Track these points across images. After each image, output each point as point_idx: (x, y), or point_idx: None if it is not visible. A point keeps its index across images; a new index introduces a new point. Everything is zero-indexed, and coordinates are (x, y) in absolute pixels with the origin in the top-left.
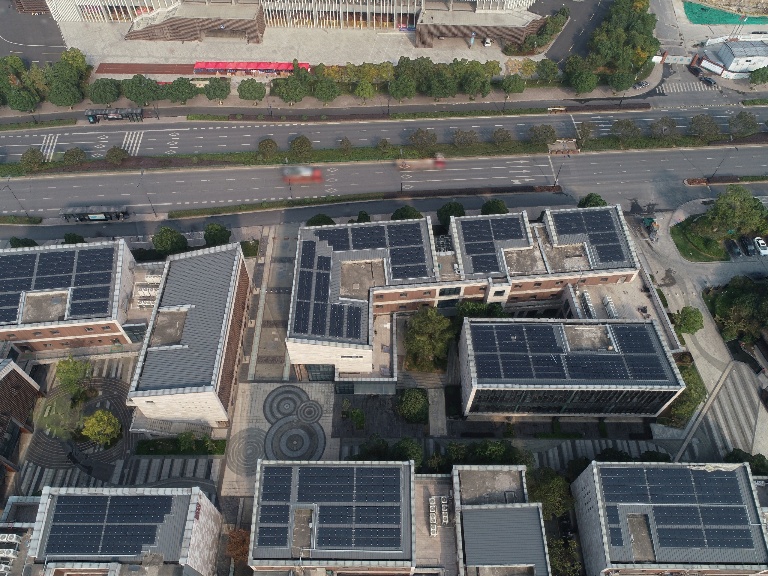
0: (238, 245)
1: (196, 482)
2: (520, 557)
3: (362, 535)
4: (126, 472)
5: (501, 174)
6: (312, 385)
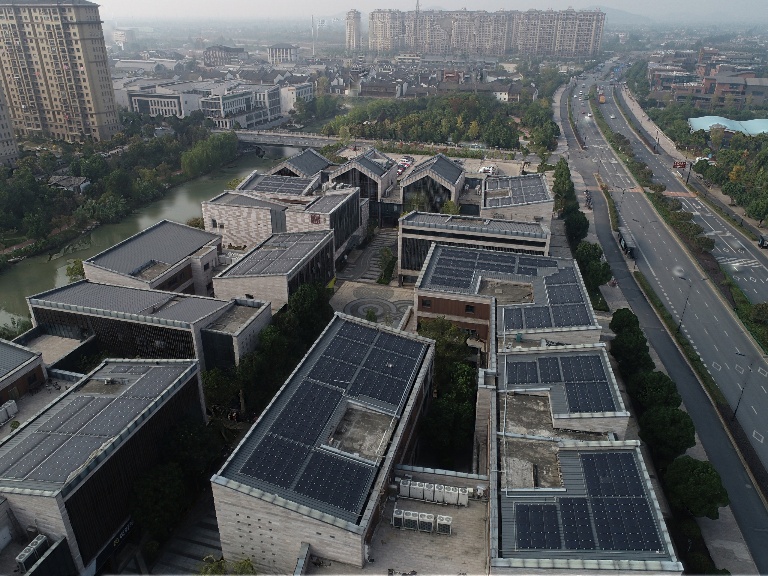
0: (548, 232)
1: (361, 274)
2: (167, 311)
3: None
4: None
5: None
6: None
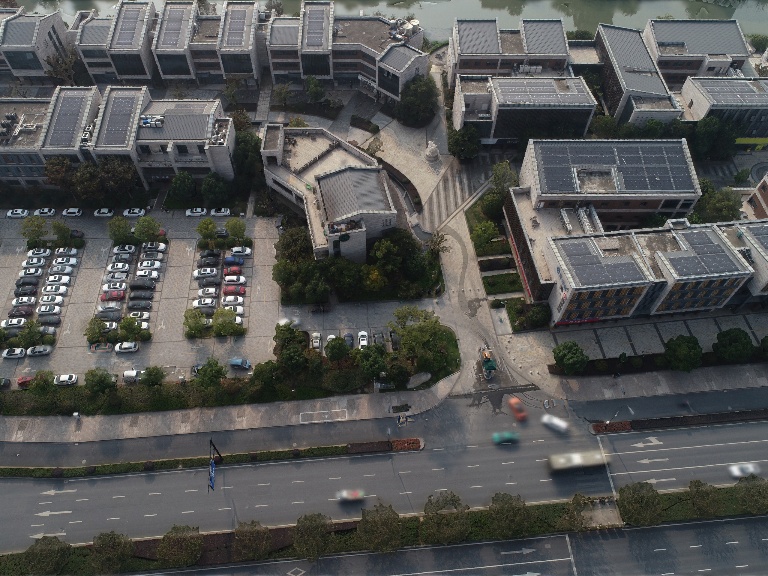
0: None
1: None
2: (633, 75)
3: (724, 85)
4: None
5: (679, 455)
6: None
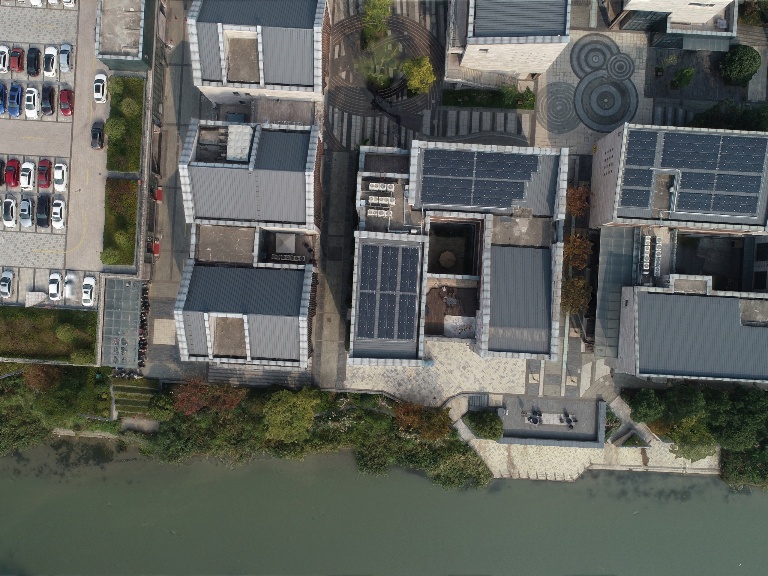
0: None
1: (508, 137)
2: None
3: (721, 201)
4: (436, 123)
5: None
6: (623, 35)
